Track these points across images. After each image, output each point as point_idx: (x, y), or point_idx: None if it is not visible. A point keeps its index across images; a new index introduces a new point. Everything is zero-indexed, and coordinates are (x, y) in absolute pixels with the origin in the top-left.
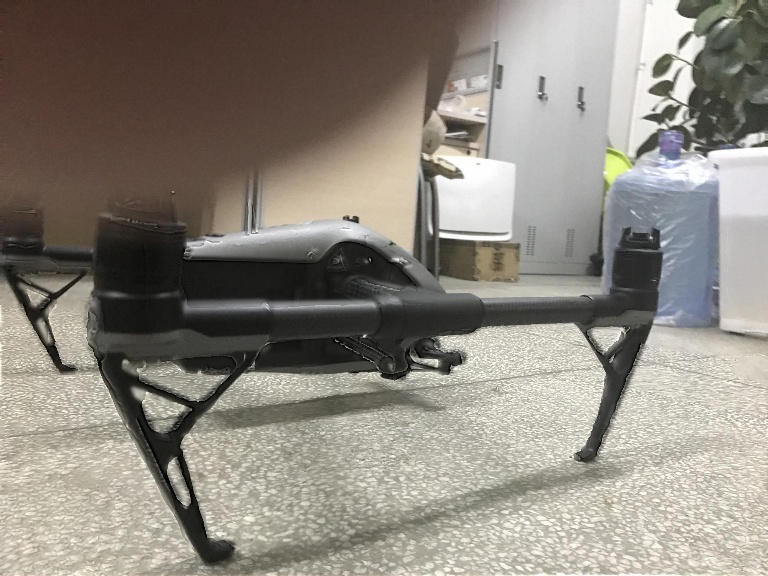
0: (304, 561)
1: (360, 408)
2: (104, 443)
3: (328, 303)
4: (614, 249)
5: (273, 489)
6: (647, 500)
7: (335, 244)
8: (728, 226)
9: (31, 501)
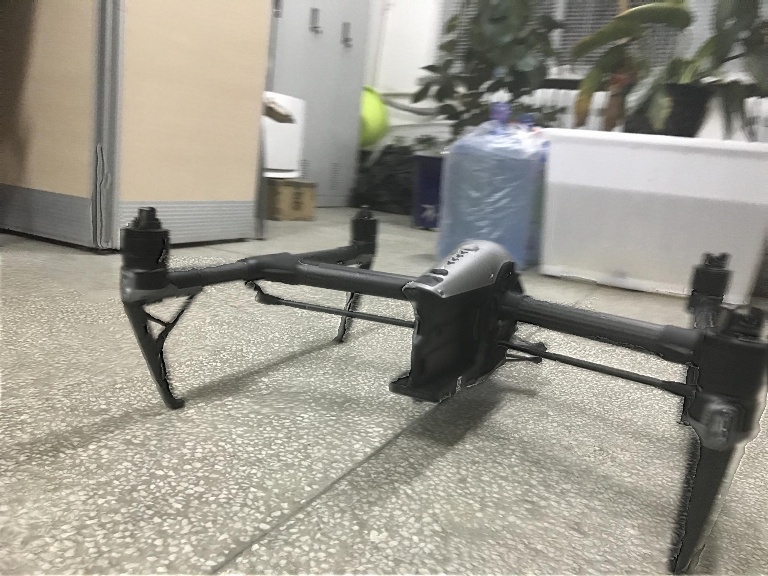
0: (725, 556)
1: (496, 403)
2: (397, 488)
3: (496, 318)
4: (708, 267)
5: (595, 501)
6: (765, 450)
7: (503, 264)
8: (556, 191)
9: (480, 567)
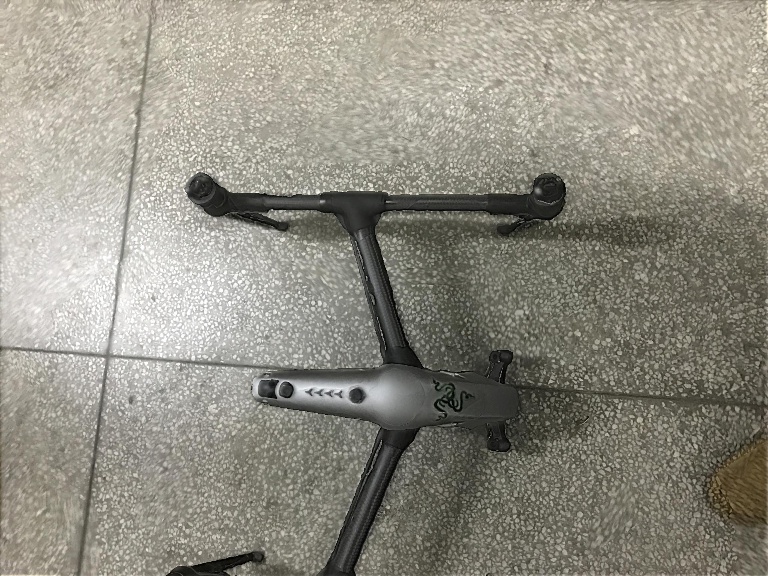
0: None
1: None
2: None
3: None
4: None
5: (306, 510)
6: None
7: None
8: None
9: (214, 461)
